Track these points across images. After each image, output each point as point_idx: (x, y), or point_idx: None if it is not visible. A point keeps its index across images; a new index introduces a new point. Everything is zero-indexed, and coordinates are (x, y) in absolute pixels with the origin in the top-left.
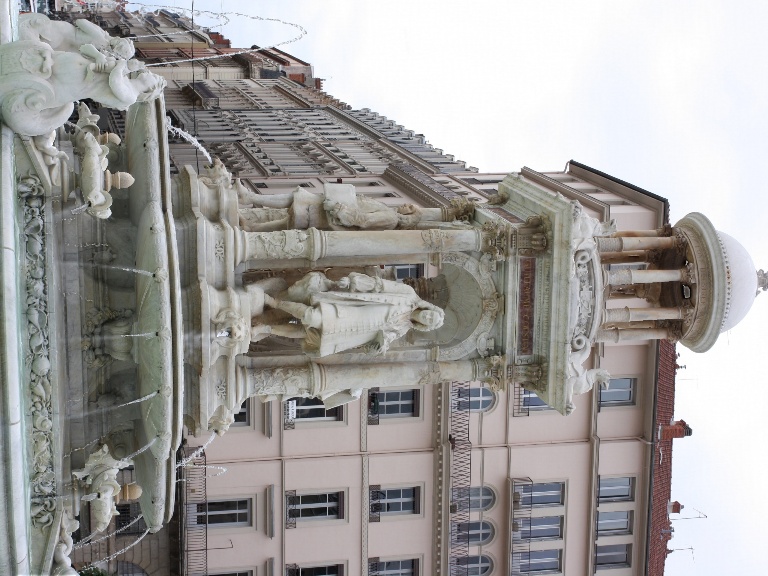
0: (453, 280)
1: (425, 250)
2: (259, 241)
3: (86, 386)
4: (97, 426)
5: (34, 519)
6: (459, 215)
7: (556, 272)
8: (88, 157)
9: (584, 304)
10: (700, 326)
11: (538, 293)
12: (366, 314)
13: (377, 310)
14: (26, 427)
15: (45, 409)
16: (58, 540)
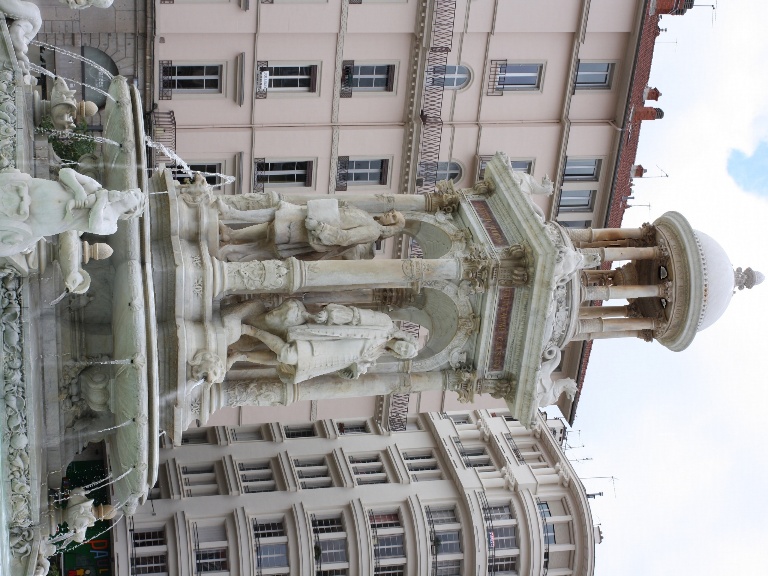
0: (431, 288)
1: (405, 281)
2: (238, 276)
3: (63, 429)
4: (73, 445)
5: (13, 549)
6: (443, 206)
7: (534, 307)
8: (66, 236)
9: (559, 323)
10: (671, 334)
11: (514, 319)
12: (342, 349)
13: (353, 345)
14: (5, 492)
15: (23, 477)
16: (36, 565)
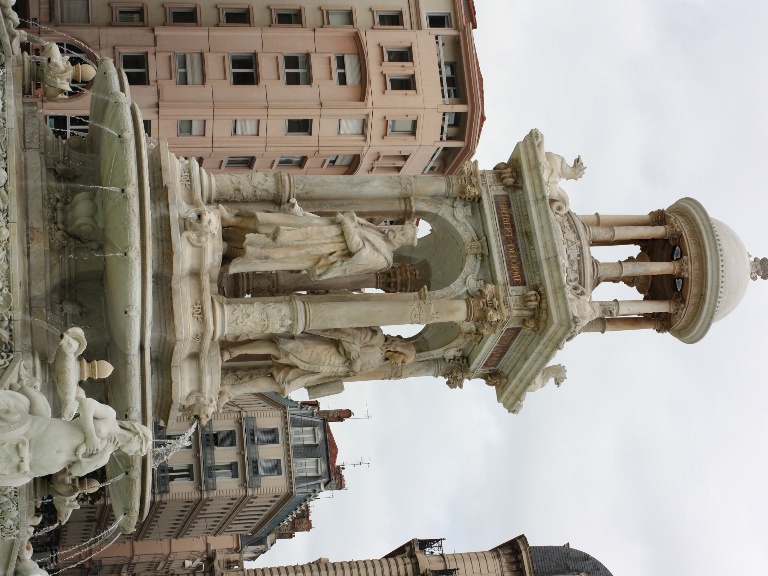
0: None
1: None
2: None
3: None
4: None
5: None
6: None
7: None
8: None
9: None
10: None
11: None
12: None
13: None
14: None
15: None
16: None
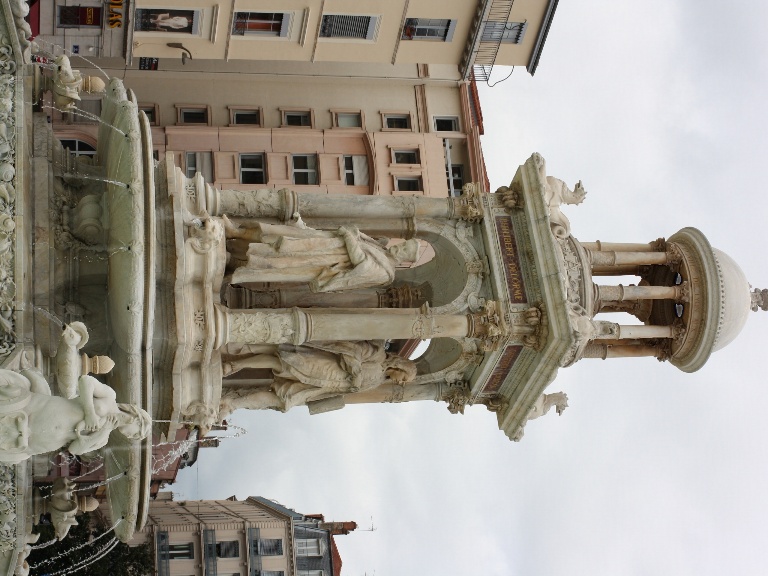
0: None
1: None
2: None
3: None
4: None
5: None
6: None
7: None
8: None
9: None
10: None
11: None
12: None
13: None
14: None
15: None
16: None
